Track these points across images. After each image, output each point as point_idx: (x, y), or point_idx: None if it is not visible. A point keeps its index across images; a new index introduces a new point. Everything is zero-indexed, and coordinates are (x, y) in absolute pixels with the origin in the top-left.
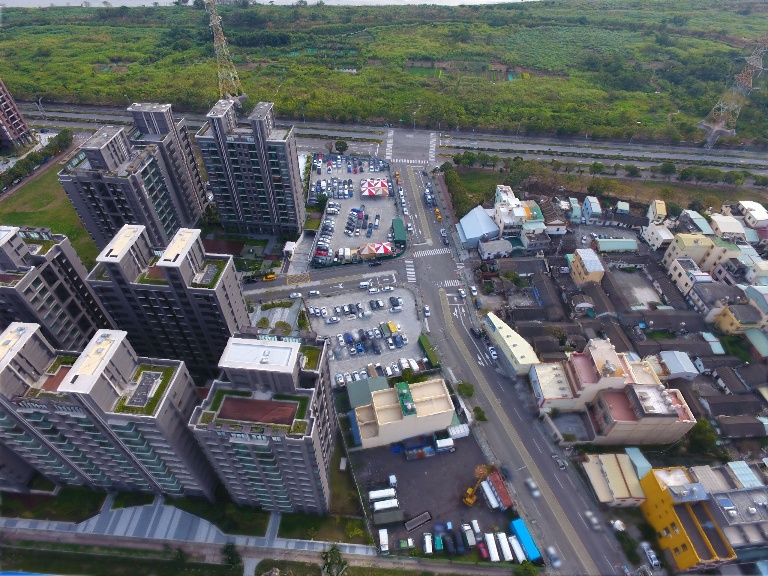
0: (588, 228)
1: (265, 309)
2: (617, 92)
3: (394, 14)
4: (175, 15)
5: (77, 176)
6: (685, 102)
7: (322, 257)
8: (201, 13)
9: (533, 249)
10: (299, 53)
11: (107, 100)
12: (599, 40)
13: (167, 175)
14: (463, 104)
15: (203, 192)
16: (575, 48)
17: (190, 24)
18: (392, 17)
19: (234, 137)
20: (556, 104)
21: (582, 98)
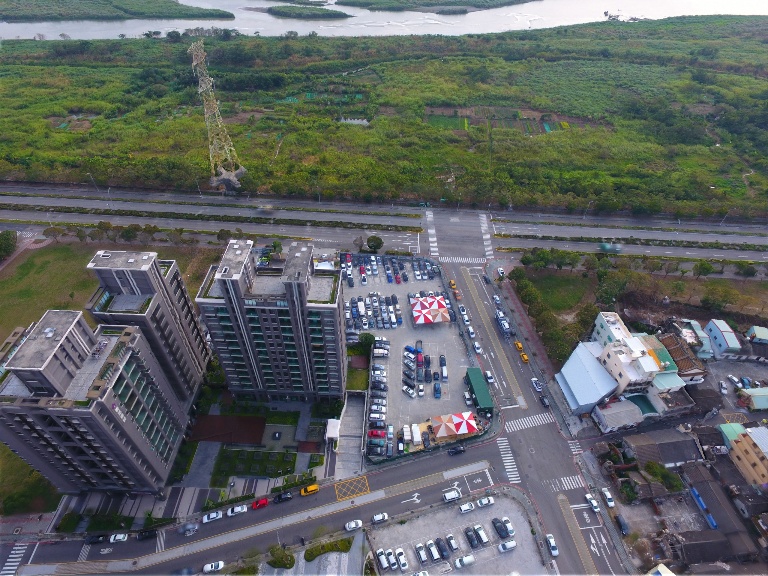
0: (720, 365)
1: (311, 558)
2: (676, 147)
3: (397, 47)
4: (146, 50)
5: (2, 408)
6: (758, 160)
7: (380, 442)
8: (176, 47)
9: (669, 415)
10: (297, 98)
11: (64, 178)
12: (631, 77)
13: (153, 362)
14: (505, 168)
15: (203, 345)
16: (608, 88)
17: (164, 62)
18: (396, 51)
19: (256, 300)
20: (611, 164)
21: (638, 155)
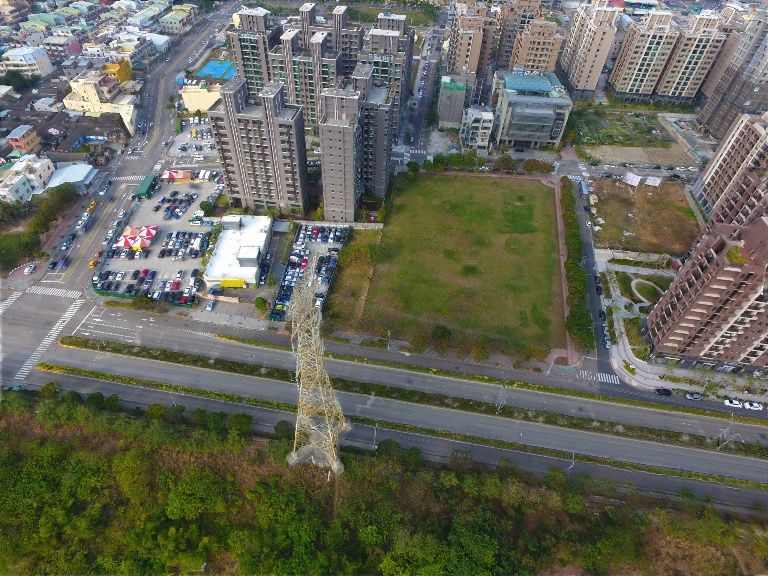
0: None
1: None
2: None
3: None
4: None
5: None
6: None
7: None
8: None
9: None
10: None
11: (633, 491)
12: None
13: None
14: None
15: None
16: None
17: None
18: None
19: None
20: None
21: None
